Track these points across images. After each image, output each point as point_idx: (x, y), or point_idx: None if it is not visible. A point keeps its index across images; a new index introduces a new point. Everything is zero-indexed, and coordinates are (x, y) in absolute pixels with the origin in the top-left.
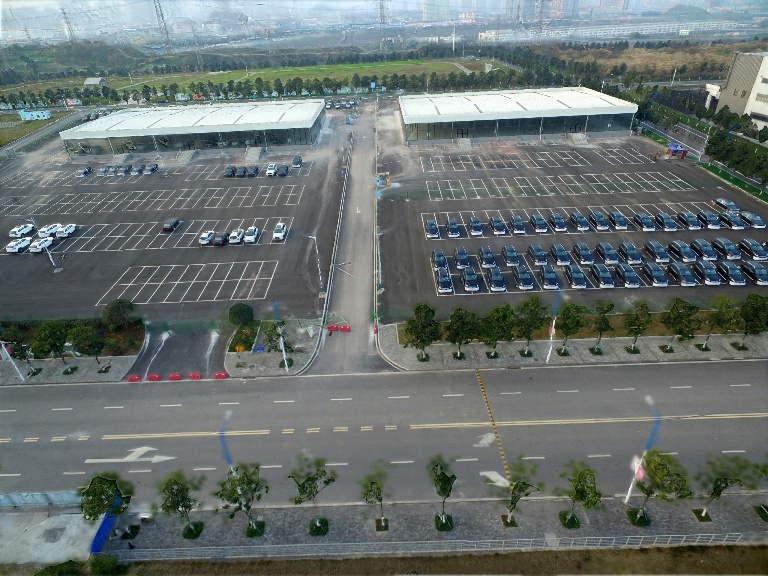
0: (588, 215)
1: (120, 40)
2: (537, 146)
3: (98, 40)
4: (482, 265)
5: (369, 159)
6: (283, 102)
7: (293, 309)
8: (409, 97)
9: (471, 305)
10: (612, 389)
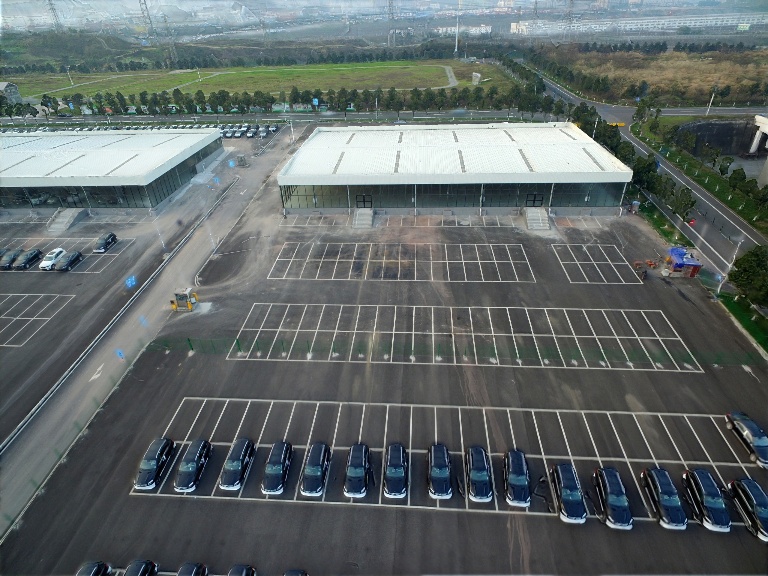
0: (472, 439)
1: (105, 29)
2: (469, 229)
3: (84, 29)
4: None
5: (214, 240)
6: (167, 131)
7: None
8: (331, 129)
9: None
10: None
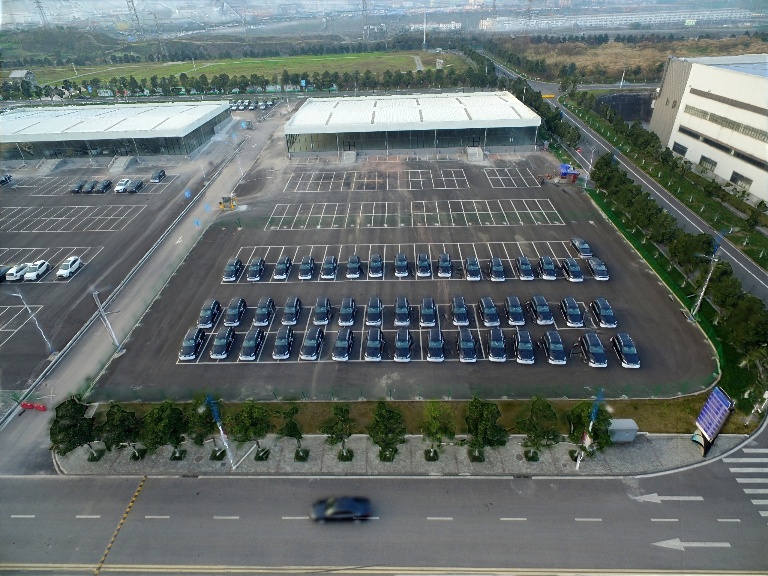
0: None
1: (92, 26)
2: (427, 162)
3: (71, 26)
4: (253, 322)
5: (239, 174)
6: (185, 103)
7: (5, 375)
8: (319, 100)
9: (203, 379)
10: (281, 517)
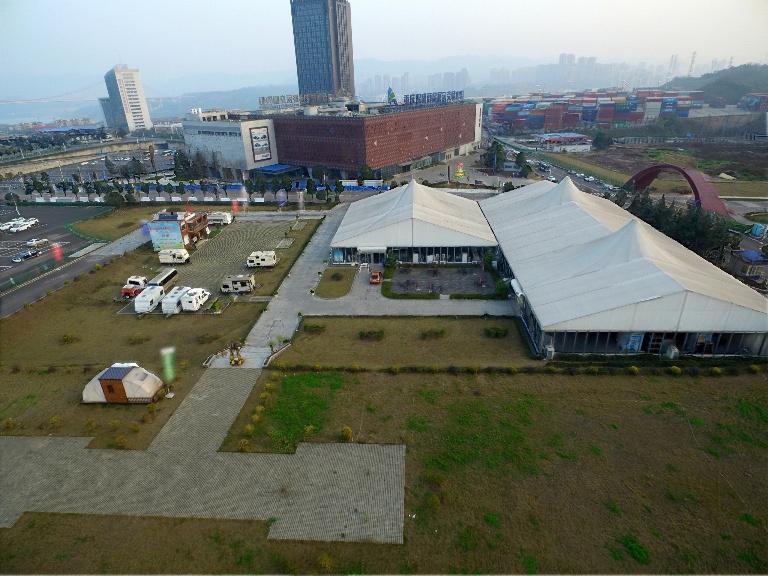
0: None
1: None
2: None
3: None
4: None
5: None
6: None
7: None
8: None
9: None
10: None
